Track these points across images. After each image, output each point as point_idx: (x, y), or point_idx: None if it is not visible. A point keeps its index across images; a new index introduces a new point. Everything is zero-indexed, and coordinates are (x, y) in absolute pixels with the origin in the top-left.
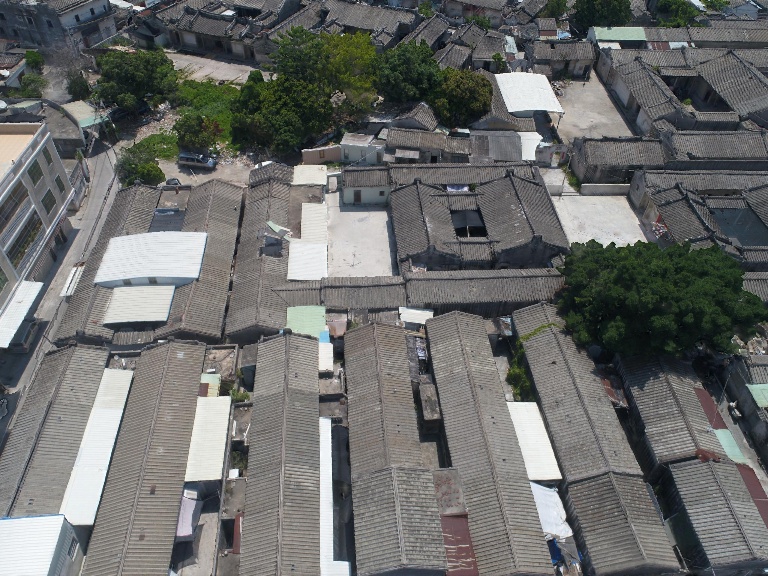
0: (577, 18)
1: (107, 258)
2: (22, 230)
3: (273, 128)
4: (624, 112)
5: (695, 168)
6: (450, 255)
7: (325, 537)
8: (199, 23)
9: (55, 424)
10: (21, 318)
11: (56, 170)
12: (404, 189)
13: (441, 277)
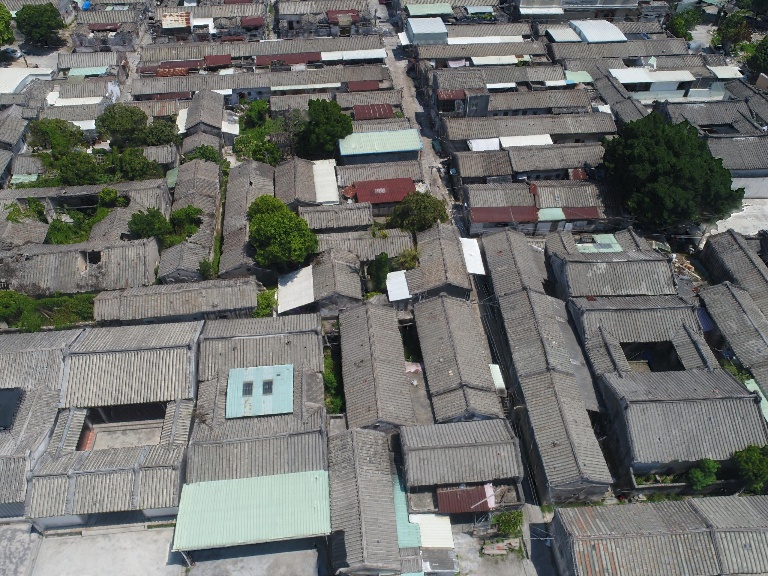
0: None
1: (589, 21)
2: None
3: (763, 47)
4: None
5: None
6: (669, 116)
7: None
8: None
9: (487, 27)
10: (539, 13)
11: None
12: None
13: None
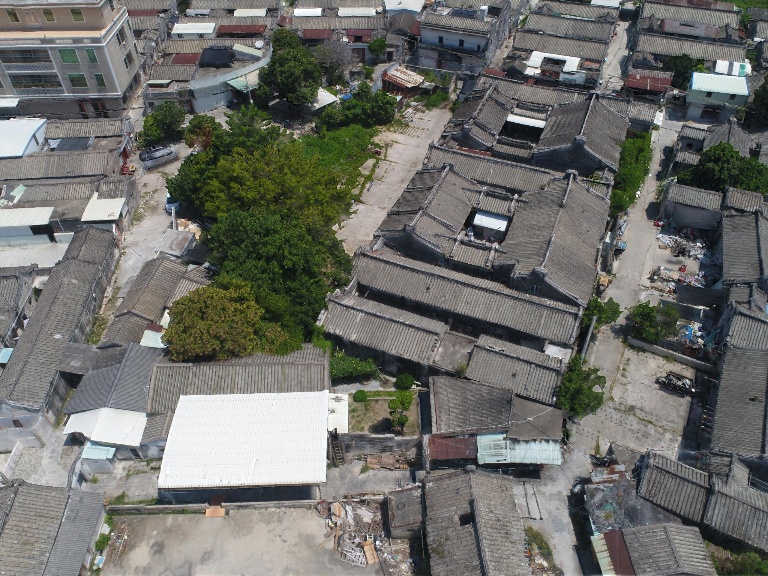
0: None
1: (21, 121)
2: (35, 75)
3: None
4: None
5: None
6: None
7: None
8: (471, 103)
9: None
10: None
11: (101, 70)
12: None
13: None
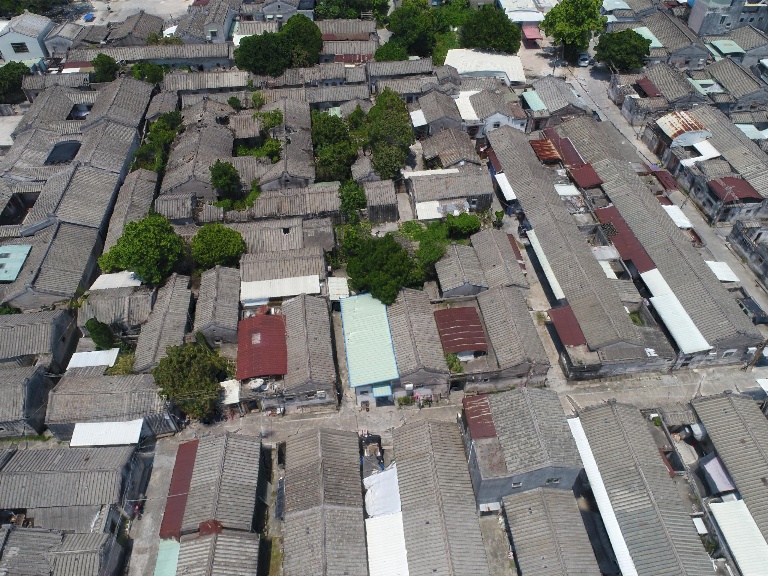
0: None
1: None
2: None
3: None
4: None
5: None
6: None
7: (588, 454)
8: None
9: None
10: None
11: None
12: None
13: None
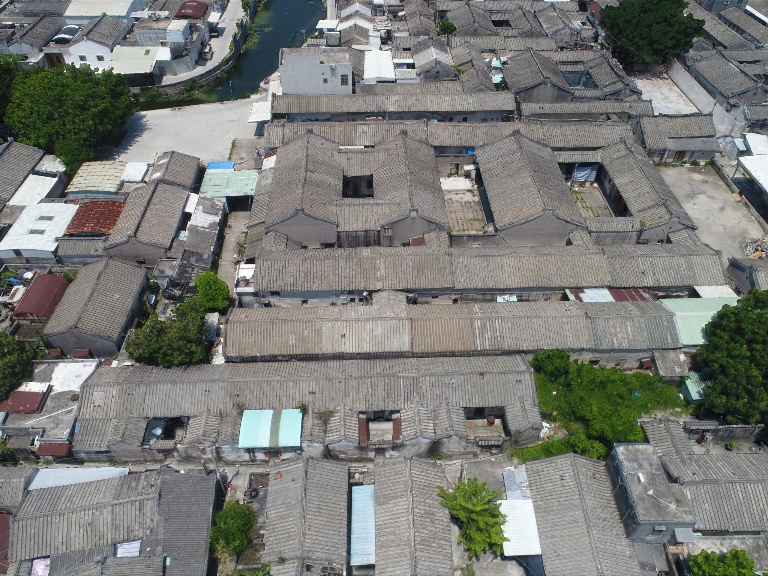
0: None
1: None
2: None
3: None
4: None
5: (601, 119)
6: None
7: None
8: None
9: None
10: None
11: None
12: None
13: (762, 50)
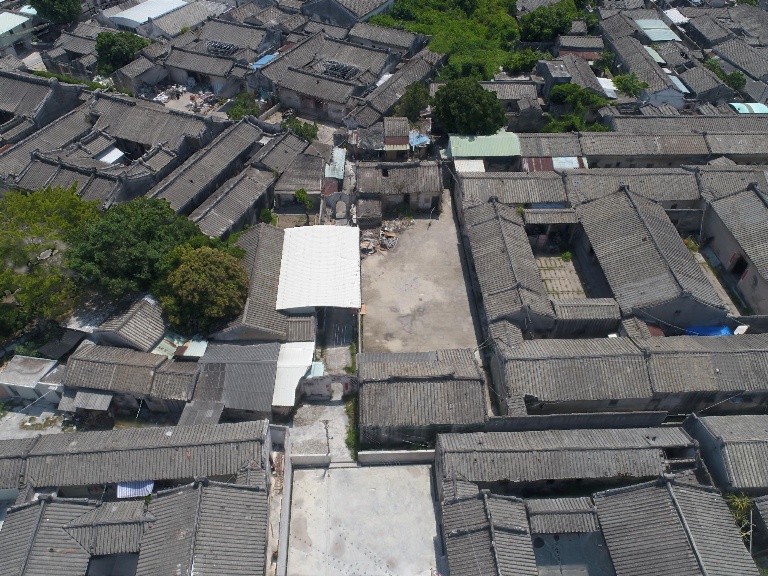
0: (437, 118)
1: None
2: None
3: None
4: (472, 279)
5: (535, 424)
6: None
7: None
8: None
9: None
10: None
11: None
12: (24, 511)
13: None
